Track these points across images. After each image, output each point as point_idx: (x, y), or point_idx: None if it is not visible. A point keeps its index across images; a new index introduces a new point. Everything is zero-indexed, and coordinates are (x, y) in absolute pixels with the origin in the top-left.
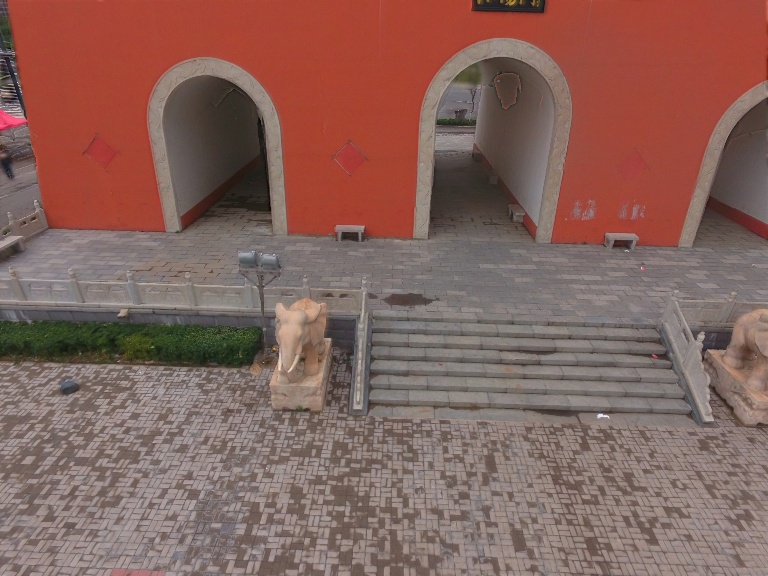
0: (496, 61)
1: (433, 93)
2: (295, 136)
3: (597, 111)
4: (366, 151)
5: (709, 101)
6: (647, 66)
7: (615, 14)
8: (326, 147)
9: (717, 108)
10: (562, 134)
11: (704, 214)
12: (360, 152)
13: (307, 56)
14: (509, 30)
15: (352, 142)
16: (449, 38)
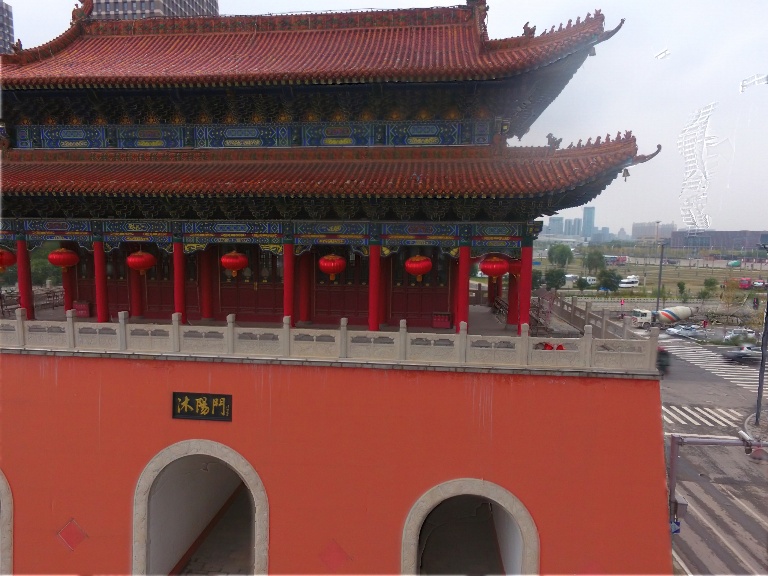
0: (196, 457)
1: (145, 481)
2: (28, 511)
3: (293, 502)
4: (88, 528)
5: (394, 498)
6: (329, 466)
7: (294, 423)
8: (53, 523)
9: (404, 504)
10: (263, 522)
11: (484, 569)
12: (82, 529)
13: (41, 447)
14: (206, 433)
15: (75, 520)
16: (157, 437)
